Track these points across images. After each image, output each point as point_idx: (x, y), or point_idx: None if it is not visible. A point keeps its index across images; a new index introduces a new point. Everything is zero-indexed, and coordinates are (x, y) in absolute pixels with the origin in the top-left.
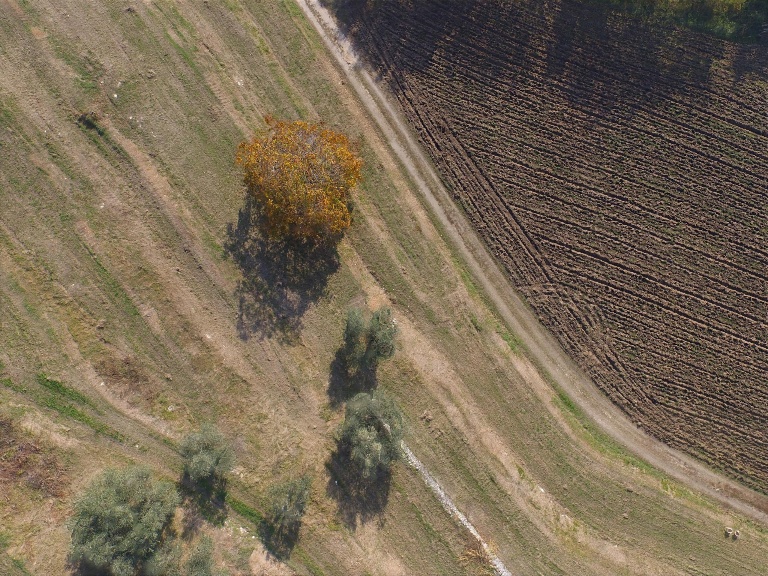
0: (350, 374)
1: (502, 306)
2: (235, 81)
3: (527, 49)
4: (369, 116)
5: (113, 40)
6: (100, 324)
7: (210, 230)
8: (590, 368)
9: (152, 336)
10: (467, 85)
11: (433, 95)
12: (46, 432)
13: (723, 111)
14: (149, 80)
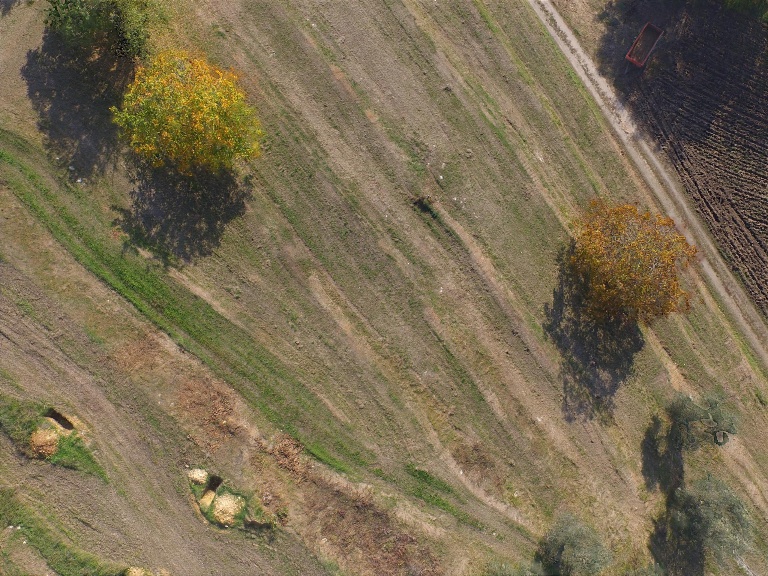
0: (659, 453)
1: None
2: (537, 157)
3: None
4: (647, 186)
5: (433, 120)
6: (451, 411)
7: (529, 310)
8: None
9: (496, 422)
10: (745, 155)
11: (711, 165)
12: (418, 522)
13: None
14: (468, 160)
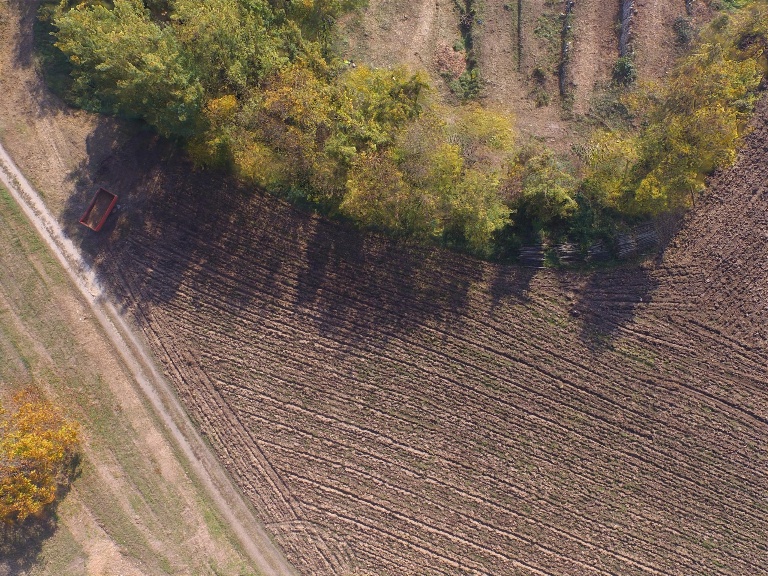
0: None
1: (249, 545)
2: None
3: (278, 277)
4: (114, 350)
5: None
6: None
7: None
8: None
9: None
10: (215, 316)
11: (180, 327)
12: None
13: (479, 337)
14: None
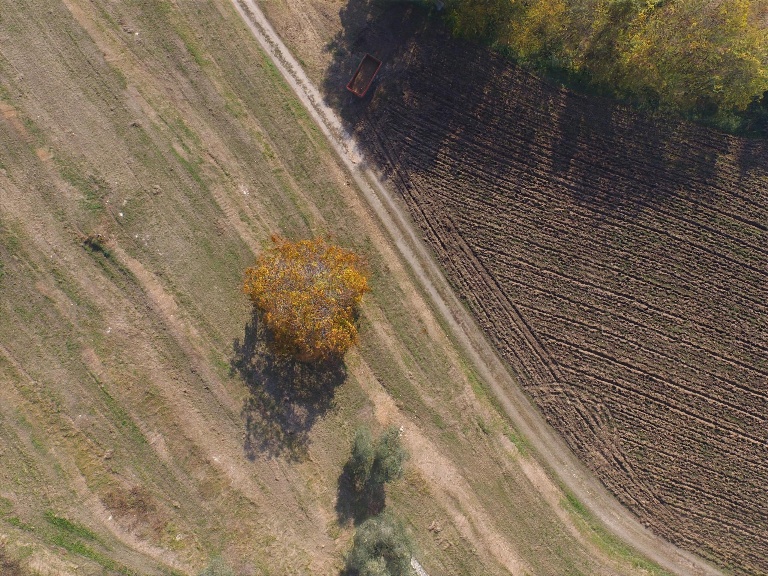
0: (358, 488)
1: (509, 406)
2: (241, 190)
3: (532, 146)
4: (375, 216)
5: (118, 156)
6: (107, 455)
7: (217, 347)
8: (598, 468)
9: (160, 464)
10: (472, 183)
11: (438, 194)
12: (54, 572)
13: (729, 207)
14: (155, 196)
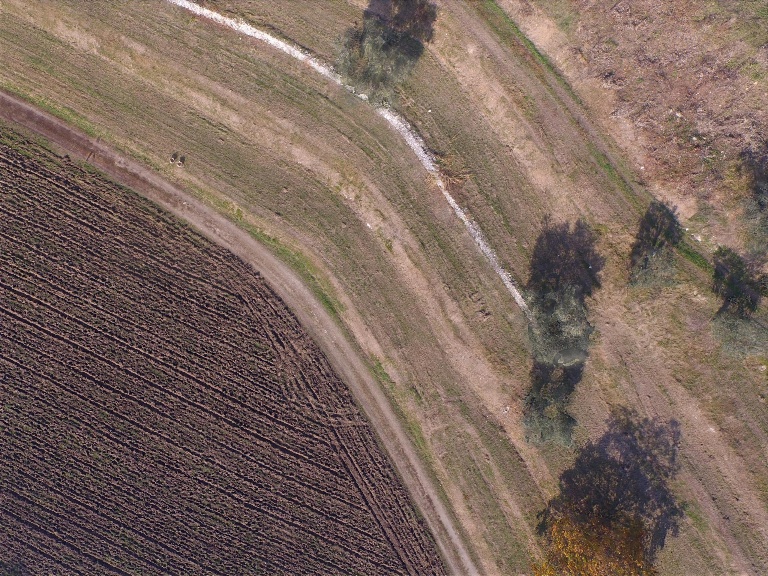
0: (561, 368)
1: (385, 407)
2: None
3: None
4: None
5: None
6: None
7: (697, 533)
8: (301, 337)
9: None
10: None
11: None
12: None
13: None
14: None
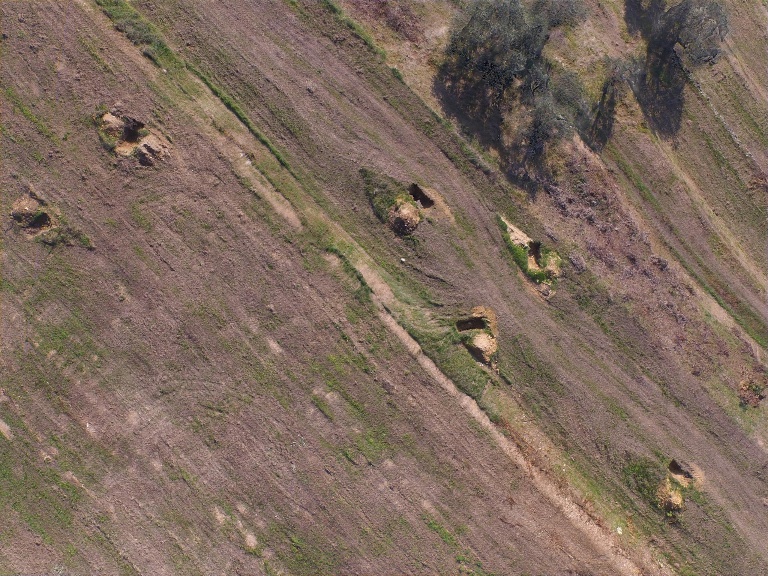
0: (642, 7)
1: None
2: None
3: None
4: None
5: None
6: None
7: None
8: None
9: None
10: None
11: None
12: None
13: None
14: None
